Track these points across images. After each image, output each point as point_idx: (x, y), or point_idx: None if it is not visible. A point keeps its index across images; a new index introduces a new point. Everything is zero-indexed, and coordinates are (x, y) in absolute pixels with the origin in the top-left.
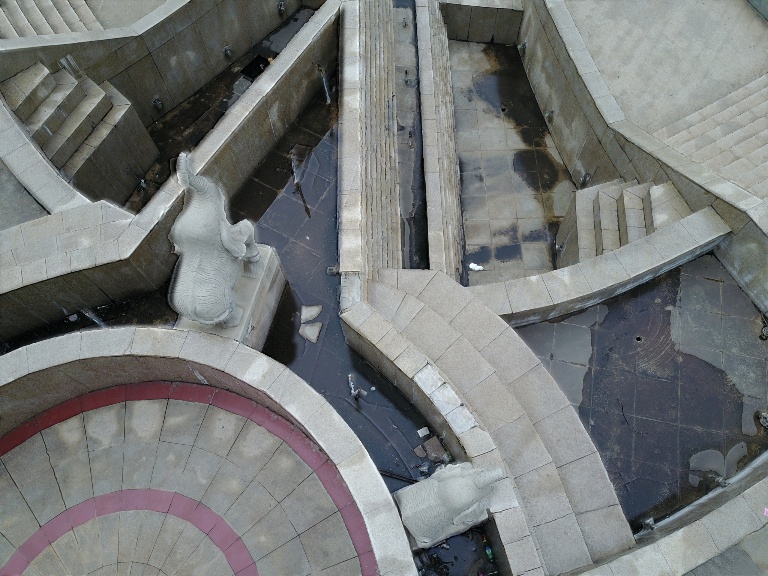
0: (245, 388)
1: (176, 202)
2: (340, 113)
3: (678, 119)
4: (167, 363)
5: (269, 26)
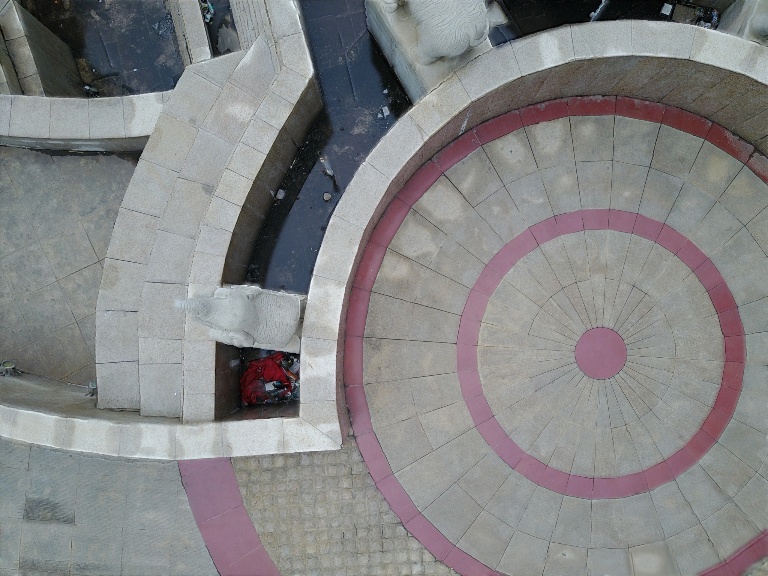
0: (522, 91)
1: None
2: None
3: None
4: (450, 125)
5: None
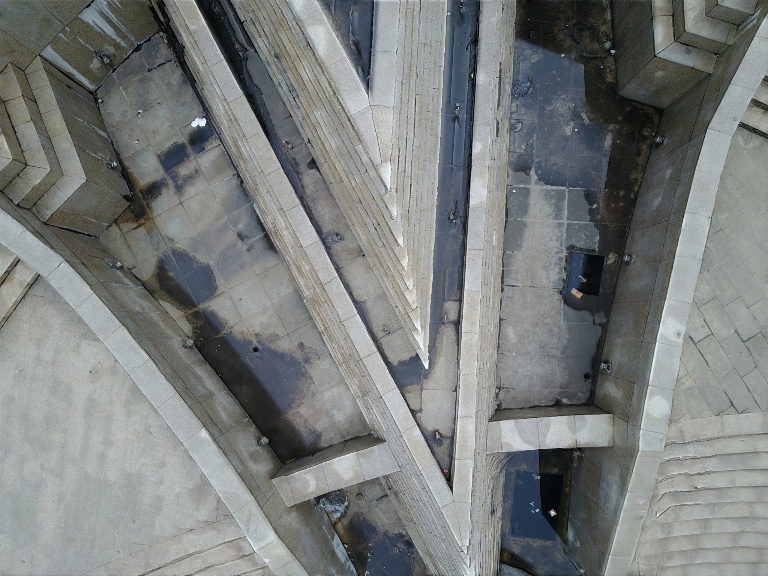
0: None
1: None
2: None
3: (3, 336)
4: None
5: None
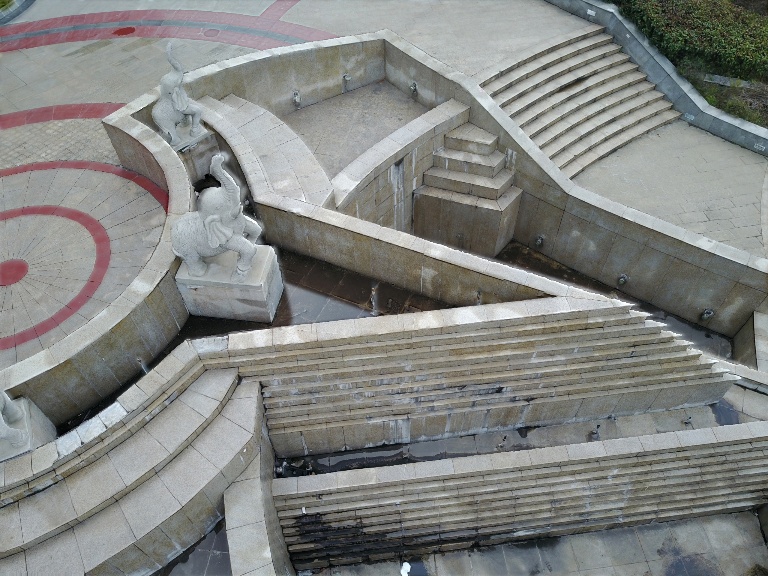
0: None
1: (308, 219)
2: (410, 314)
3: None
4: None
5: (681, 310)
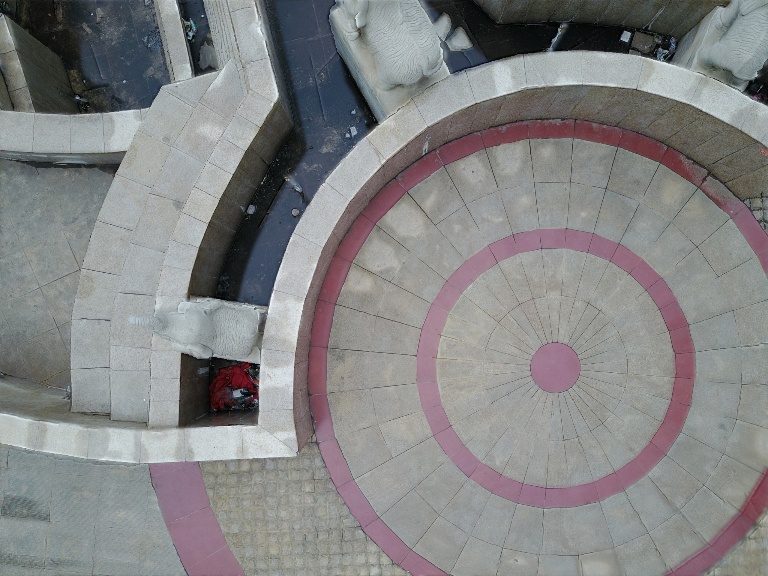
0: (480, 116)
1: None
2: None
3: None
4: (409, 148)
5: None
